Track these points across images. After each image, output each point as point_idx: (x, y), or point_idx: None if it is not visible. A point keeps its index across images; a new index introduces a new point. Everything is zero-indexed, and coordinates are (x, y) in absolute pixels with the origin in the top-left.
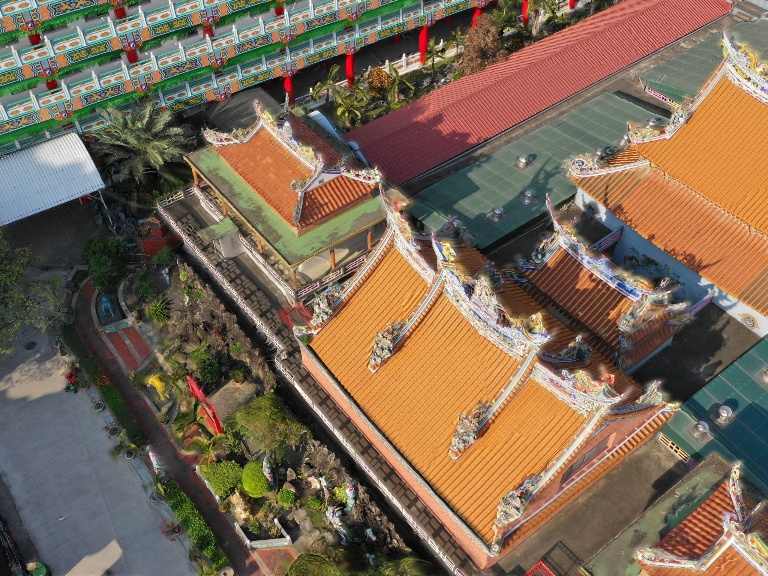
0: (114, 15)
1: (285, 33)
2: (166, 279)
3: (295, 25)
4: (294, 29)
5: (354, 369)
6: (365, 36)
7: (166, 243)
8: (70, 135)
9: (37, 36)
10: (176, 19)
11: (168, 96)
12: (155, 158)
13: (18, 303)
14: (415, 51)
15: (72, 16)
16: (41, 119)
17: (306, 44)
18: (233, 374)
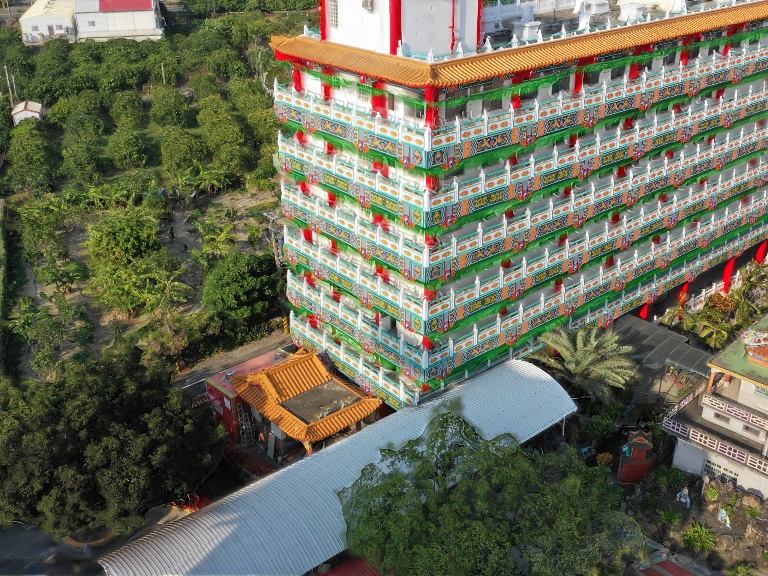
0: (558, 240)
1: (664, 259)
2: (685, 502)
3: (672, 251)
4: (670, 255)
5: None
6: (702, 264)
7: (649, 466)
8: (513, 361)
9: (509, 259)
10: (607, 243)
11: (574, 322)
12: (614, 377)
13: (615, 530)
14: (717, 281)
15: (546, 238)
16: (498, 344)
17: (666, 271)
18: None
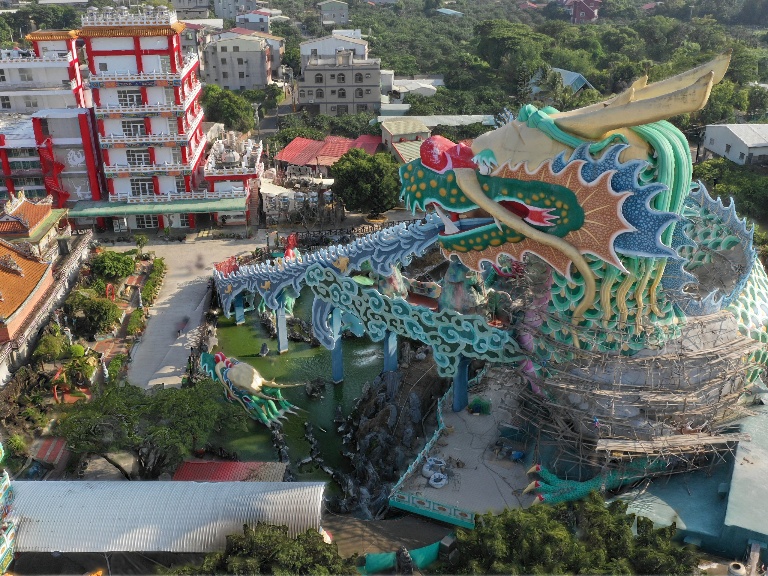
0: None
1: None
2: None
3: None
4: None
5: (7, 306)
6: None
7: None
8: None
9: None
10: None
11: None
12: None
13: None
14: None
15: None
16: None
17: None
18: (28, 400)
